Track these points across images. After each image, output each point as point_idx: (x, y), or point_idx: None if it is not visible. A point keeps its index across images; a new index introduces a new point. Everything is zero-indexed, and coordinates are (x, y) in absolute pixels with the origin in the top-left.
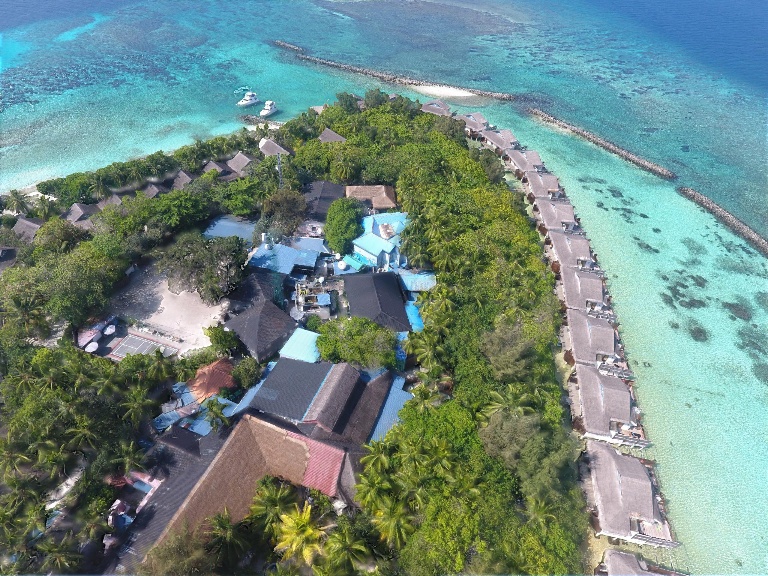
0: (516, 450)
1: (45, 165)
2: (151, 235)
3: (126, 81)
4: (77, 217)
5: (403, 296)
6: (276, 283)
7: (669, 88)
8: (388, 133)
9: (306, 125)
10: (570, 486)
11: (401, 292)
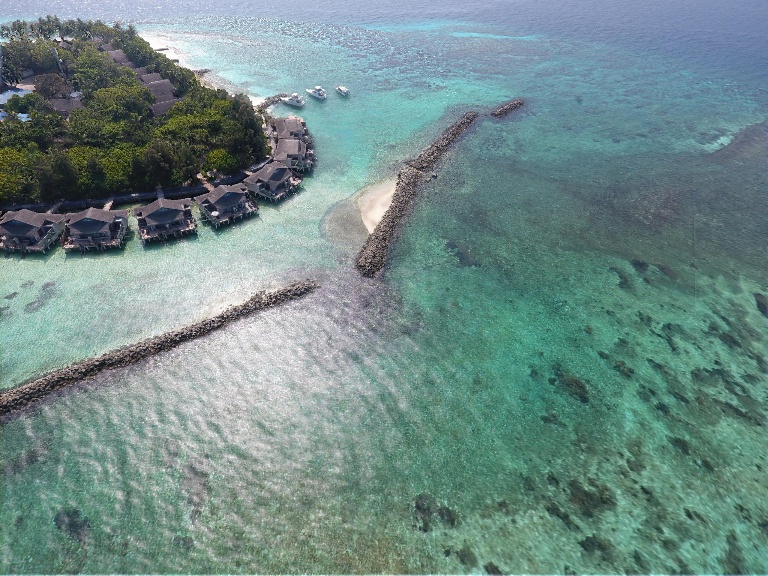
0: None
1: (212, 53)
2: None
3: None
4: None
5: None
6: None
7: None
8: None
9: None
10: None
11: None
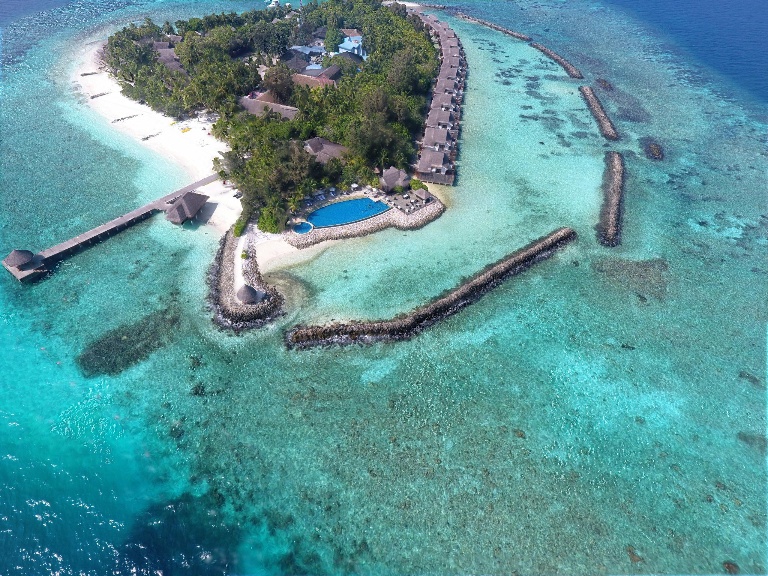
0: (398, 77)
1: None
2: (238, 41)
3: None
4: None
5: None
6: None
7: (556, 6)
8: None
9: (312, 9)
10: None
11: None
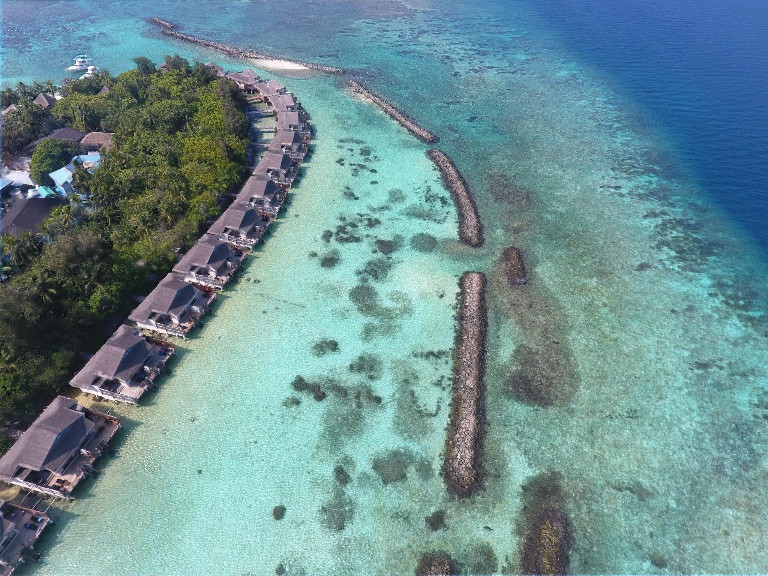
0: None
1: None
2: None
3: None
4: None
5: None
6: None
7: (509, 68)
8: (159, 92)
9: None
10: (60, 350)
11: None
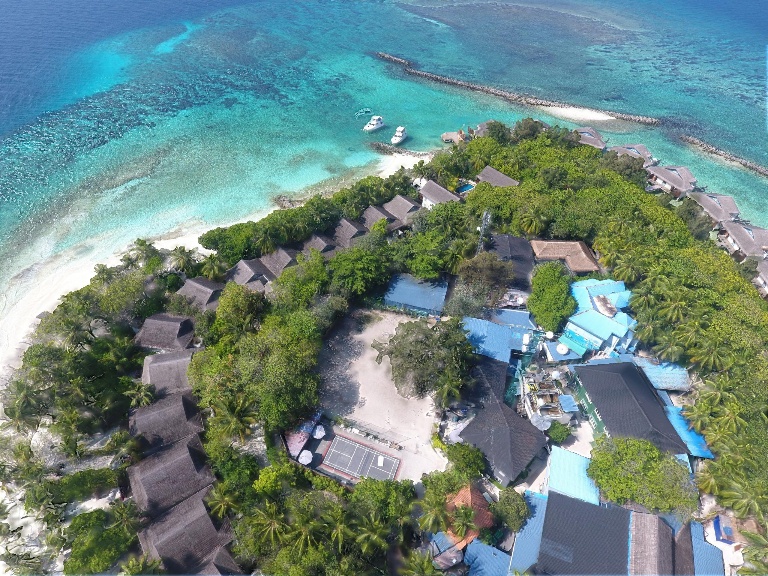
0: None
1: (182, 203)
2: (338, 305)
3: (237, 100)
4: (247, 278)
5: (657, 399)
6: (502, 377)
7: None
8: (559, 173)
9: (458, 160)
10: None
11: (652, 393)
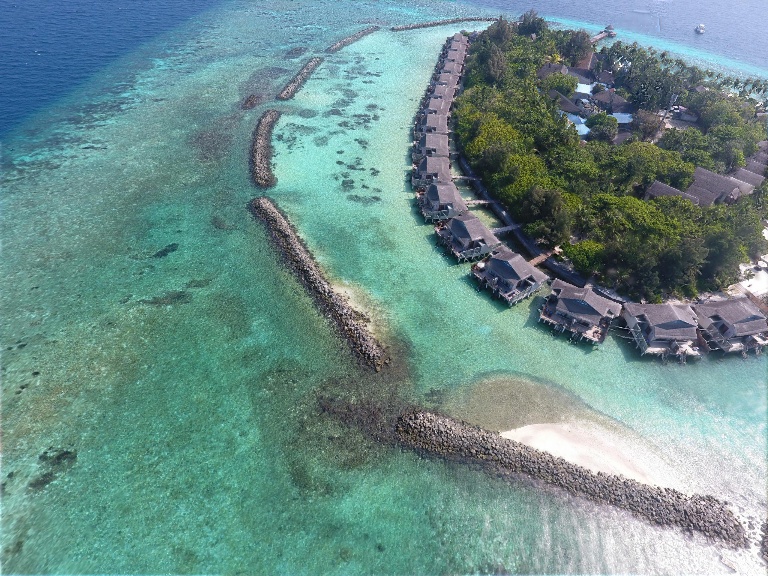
0: None
1: None
2: None
3: None
4: None
5: None
6: None
7: None
8: None
9: None
10: None
11: None
